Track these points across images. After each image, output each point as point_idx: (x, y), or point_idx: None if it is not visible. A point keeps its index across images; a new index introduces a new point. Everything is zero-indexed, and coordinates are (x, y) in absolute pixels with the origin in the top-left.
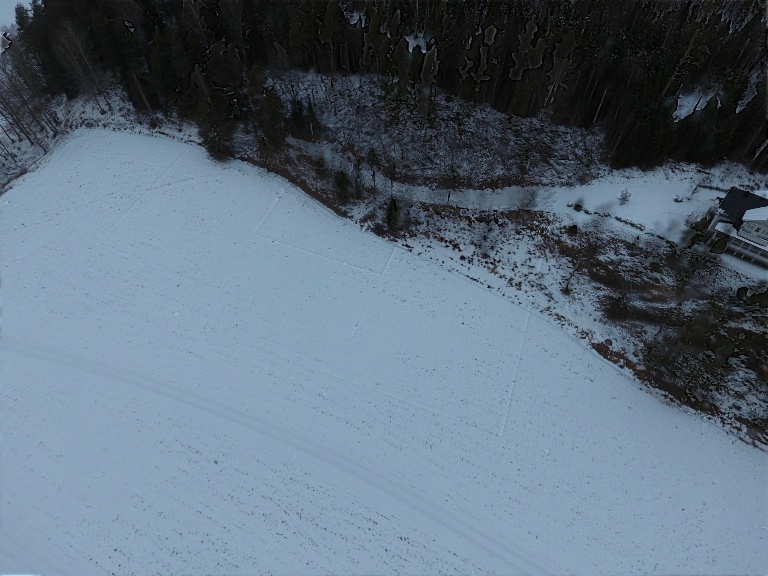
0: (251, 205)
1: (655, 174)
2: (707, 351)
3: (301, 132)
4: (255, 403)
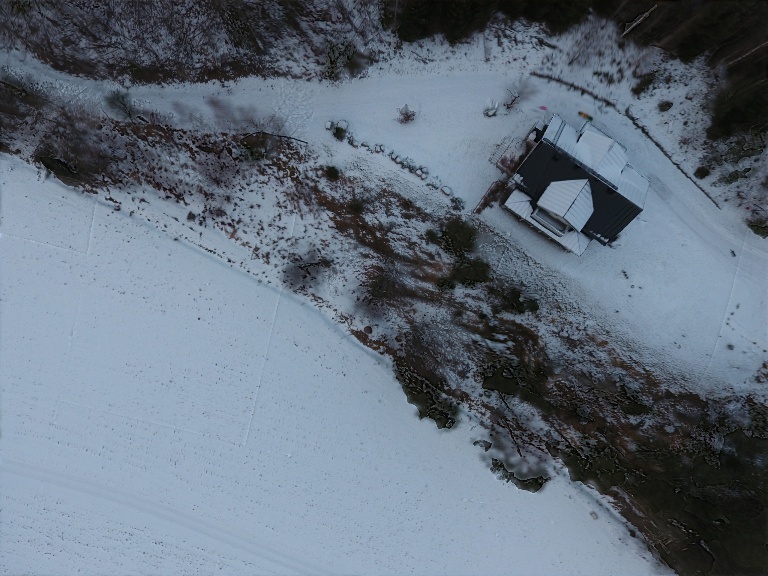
0: None
1: (469, 51)
2: (475, 336)
3: None
4: None
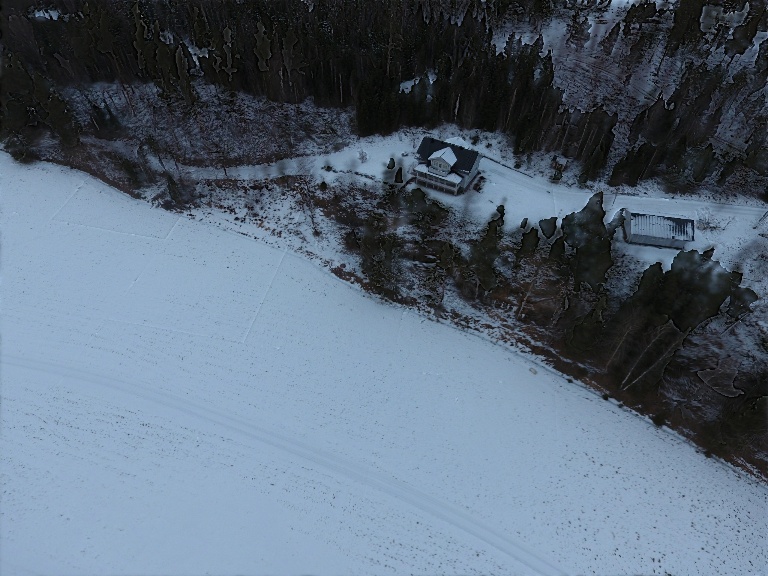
0: (51, 197)
1: (392, 138)
2: (415, 262)
3: (103, 133)
4: (31, 348)
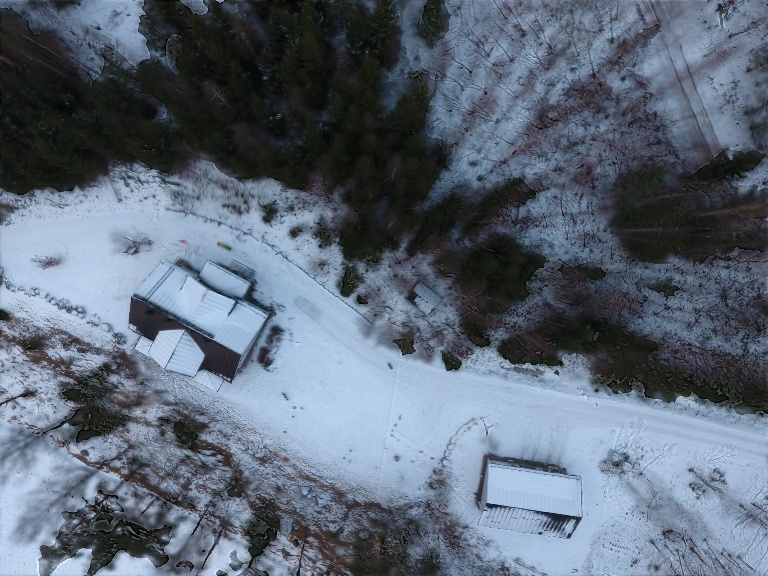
0: None
1: (99, 194)
2: (186, 451)
3: None
4: None
